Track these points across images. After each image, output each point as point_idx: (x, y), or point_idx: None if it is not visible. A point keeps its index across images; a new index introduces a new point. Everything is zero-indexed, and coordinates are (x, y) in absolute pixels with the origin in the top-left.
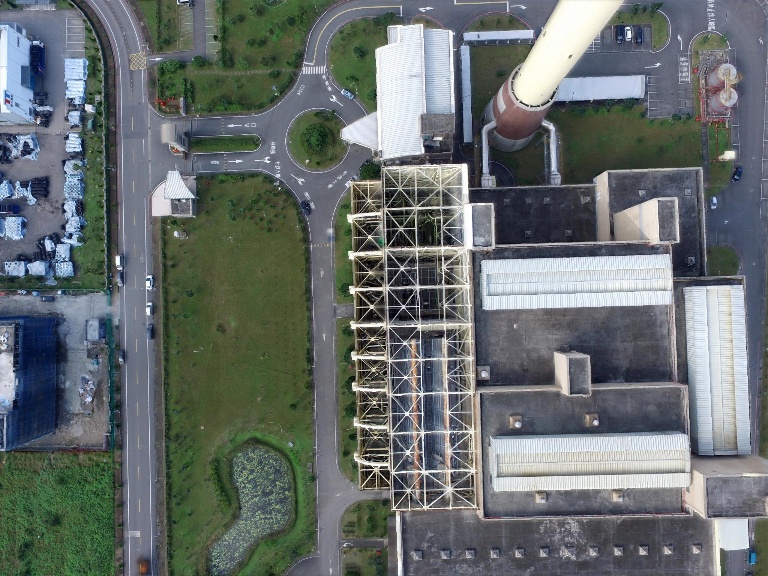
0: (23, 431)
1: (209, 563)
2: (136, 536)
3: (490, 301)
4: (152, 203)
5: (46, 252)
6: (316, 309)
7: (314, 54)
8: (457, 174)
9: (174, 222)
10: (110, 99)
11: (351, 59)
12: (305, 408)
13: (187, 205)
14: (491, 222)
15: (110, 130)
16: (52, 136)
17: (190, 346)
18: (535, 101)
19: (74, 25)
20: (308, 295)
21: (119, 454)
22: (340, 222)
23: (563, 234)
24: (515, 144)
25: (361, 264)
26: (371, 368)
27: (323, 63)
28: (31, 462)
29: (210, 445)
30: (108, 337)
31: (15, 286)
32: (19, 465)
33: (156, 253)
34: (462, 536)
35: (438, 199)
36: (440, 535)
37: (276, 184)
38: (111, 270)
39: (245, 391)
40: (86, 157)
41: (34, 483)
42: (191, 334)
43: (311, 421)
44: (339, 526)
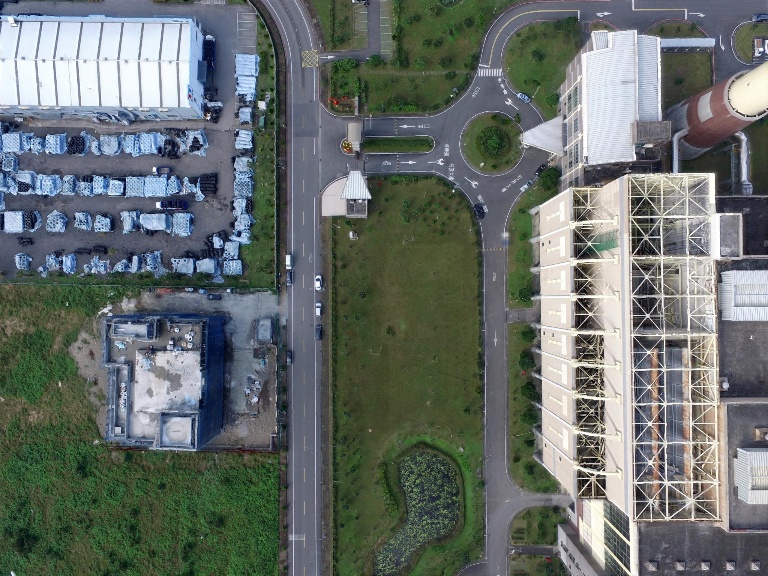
0: (206, 431)
1: (375, 567)
2: (300, 539)
3: (738, 312)
4: (322, 202)
5: (214, 250)
6: (488, 313)
7: (490, 56)
8: (703, 183)
9: (349, 222)
10: (281, 96)
11: (528, 62)
12: (476, 413)
13: (362, 206)
14: (739, 233)
15: (280, 128)
16: (221, 132)
17: (359, 348)
18: (754, 111)
19: (245, 20)
20: (481, 299)
21: (284, 455)
22: (514, 226)
23: (761, 245)
24: (698, 153)
25: (580, 271)
26: (589, 376)
27: (499, 66)
28: (195, 462)
29: (378, 448)
30: (275, 337)
31: (182, 283)
32: (183, 465)
33: (325, 253)
34: (697, 548)
35: (684, 208)
36: (675, 546)
37: (456, 187)
38: (279, 269)
39: (414, 394)
40: (256, 154)
41: (198, 483)
42: (360, 336)
43: (481, 426)
44: (508, 532)
